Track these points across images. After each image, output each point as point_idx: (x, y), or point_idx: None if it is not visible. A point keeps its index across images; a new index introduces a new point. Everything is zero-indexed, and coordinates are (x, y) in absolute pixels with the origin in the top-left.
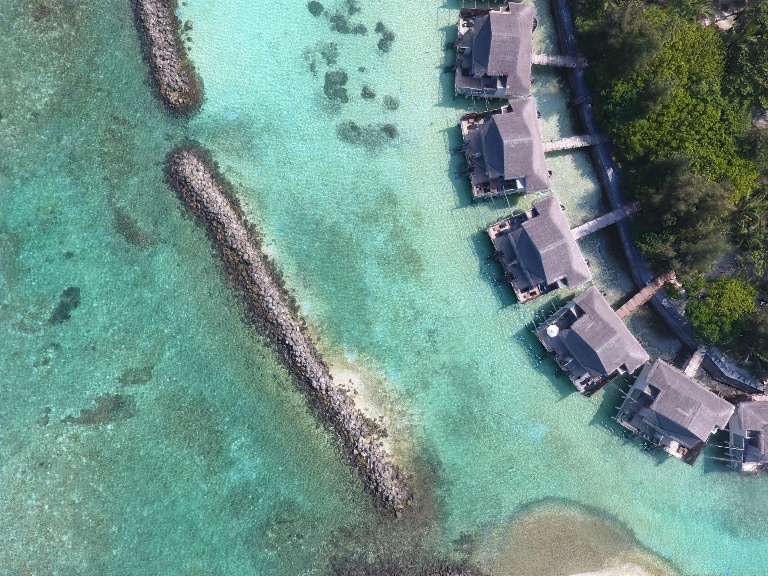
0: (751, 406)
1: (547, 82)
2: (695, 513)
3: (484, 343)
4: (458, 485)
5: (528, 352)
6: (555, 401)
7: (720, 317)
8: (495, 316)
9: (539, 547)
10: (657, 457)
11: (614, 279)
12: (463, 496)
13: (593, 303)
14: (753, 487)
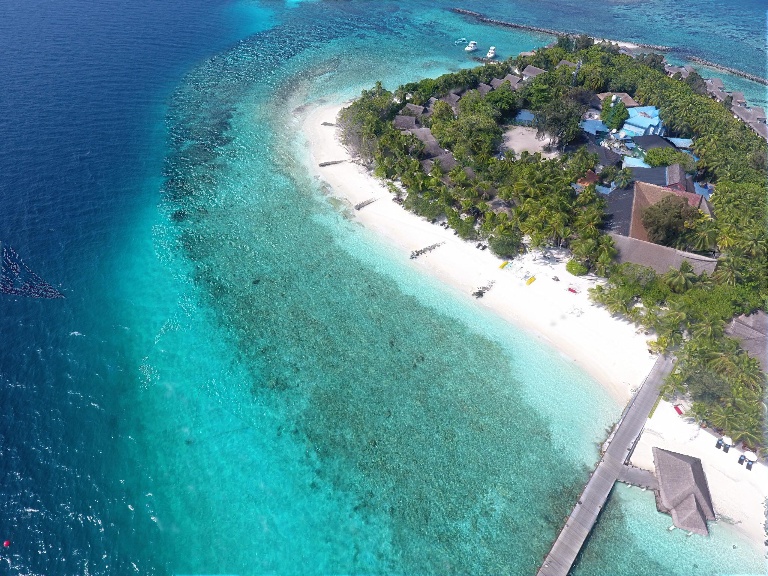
0: None
1: None
2: None
3: None
4: None
5: None
6: None
7: None
8: None
9: None
10: None
11: None
12: None
13: None
14: None
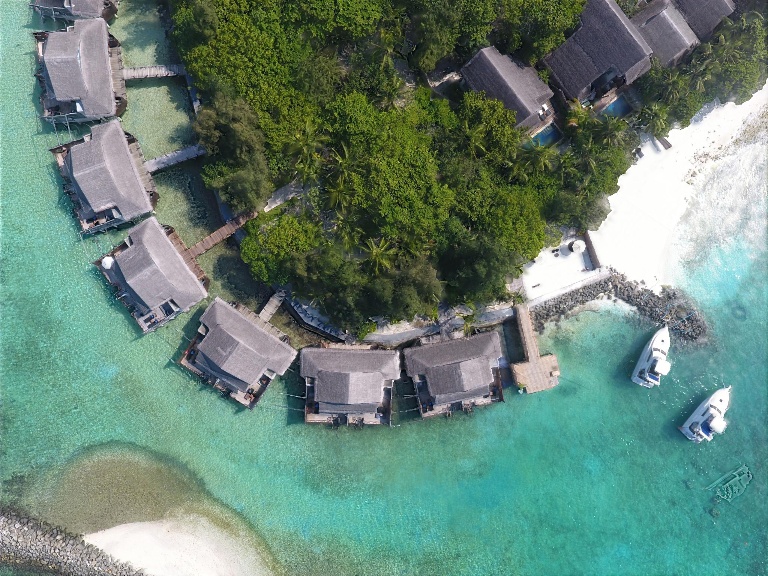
0: (312, 352)
1: (147, 10)
2: (274, 466)
3: (57, 276)
4: (15, 423)
5: (104, 288)
6: (129, 341)
7: (267, 254)
8: (72, 249)
9: (95, 492)
10: (236, 405)
11: (202, 217)
12: (19, 435)
13: (143, 234)
14: (339, 442)
